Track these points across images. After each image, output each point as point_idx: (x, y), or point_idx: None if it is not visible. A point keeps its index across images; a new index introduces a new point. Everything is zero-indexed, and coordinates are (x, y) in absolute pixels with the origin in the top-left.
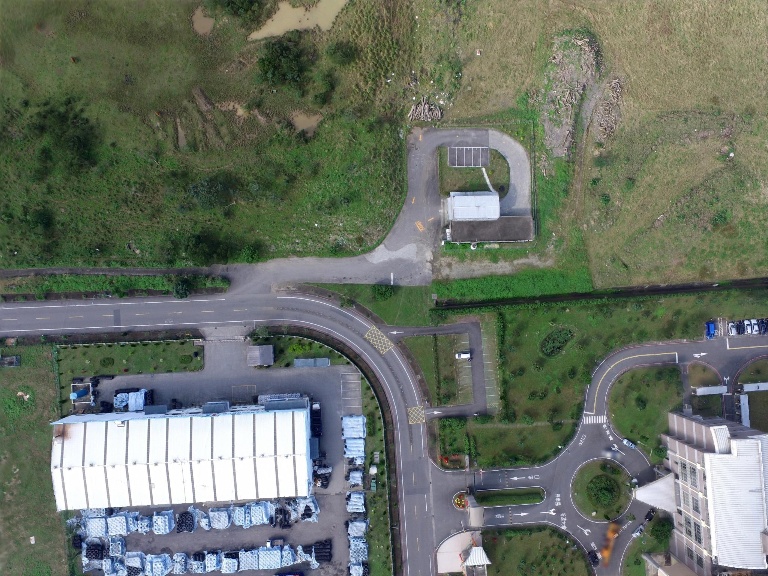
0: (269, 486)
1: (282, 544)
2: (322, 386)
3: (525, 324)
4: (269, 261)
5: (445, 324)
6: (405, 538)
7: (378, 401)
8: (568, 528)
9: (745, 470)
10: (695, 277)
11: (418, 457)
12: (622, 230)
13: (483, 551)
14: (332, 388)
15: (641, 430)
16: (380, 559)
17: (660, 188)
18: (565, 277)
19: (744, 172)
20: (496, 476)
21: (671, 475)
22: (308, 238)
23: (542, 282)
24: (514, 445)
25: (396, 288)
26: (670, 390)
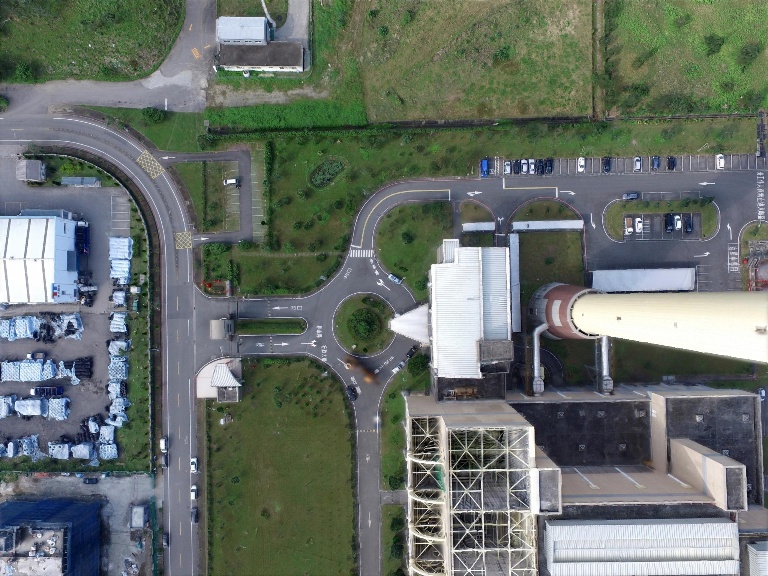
0: (20, 290)
1: (43, 357)
2: (92, 207)
3: (295, 154)
4: (47, 82)
5: (216, 151)
6: (166, 361)
7: (146, 224)
8: (328, 361)
9: (465, 278)
10: (473, 114)
11: (183, 282)
12: (400, 63)
13: (227, 368)
14: (102, 209)
15: (408, 266)
16: (139, 379)
17: (441, 22)
18: (338, 108)
19: (530, 8)
20: (259, 305)
21: (425, 305)
22: (83, 59)
23: (314, 112)
24: (278, 274)
25: (170, 114)
26: (440, 227)
